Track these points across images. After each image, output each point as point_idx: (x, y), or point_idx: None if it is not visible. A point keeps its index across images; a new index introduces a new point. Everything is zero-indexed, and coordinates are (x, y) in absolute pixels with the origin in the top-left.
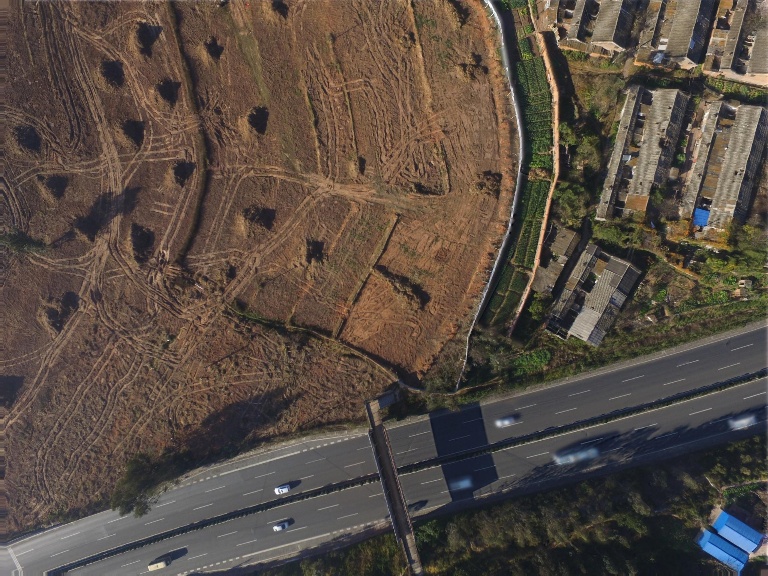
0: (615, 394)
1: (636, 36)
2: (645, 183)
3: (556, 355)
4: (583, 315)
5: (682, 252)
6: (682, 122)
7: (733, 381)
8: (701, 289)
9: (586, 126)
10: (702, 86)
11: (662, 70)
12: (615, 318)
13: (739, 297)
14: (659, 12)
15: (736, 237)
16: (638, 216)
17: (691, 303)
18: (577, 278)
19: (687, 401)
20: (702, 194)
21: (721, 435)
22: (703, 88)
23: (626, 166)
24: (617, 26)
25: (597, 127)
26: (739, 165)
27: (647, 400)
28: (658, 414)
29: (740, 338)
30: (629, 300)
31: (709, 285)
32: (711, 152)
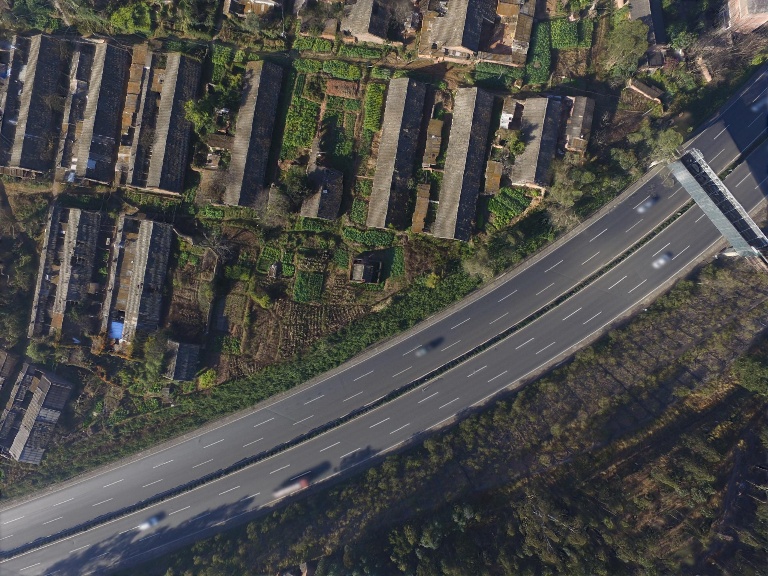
0: (97, 500)
1: (48, 158)
2: (62, 301)
3: (10, 473)
4: (19, 434)
5: (112, 363)
6: (97, 238)
7: (205, 478)
8: (132, 398)
9: (22, 246)
10: (121, 200)
11: (83, 187)
12: (52, 434)
13: (169, 403)
14: (67, 134)
15: (143, 349)
16: (57, 334)
17: (121, 413)
18: (13, 398)
19: (165, 501)
20: (116, 307)
21: (201, 532)
22: (122, 202)
23: (53, 284)
24: (23, 152)
25: (33, 246)
26: (140, 278)
27: (128, 503)
28: (140, 516)
29: (211, 435)
30: (61, 416)
31: (139, 394)
32: (121, 266)
